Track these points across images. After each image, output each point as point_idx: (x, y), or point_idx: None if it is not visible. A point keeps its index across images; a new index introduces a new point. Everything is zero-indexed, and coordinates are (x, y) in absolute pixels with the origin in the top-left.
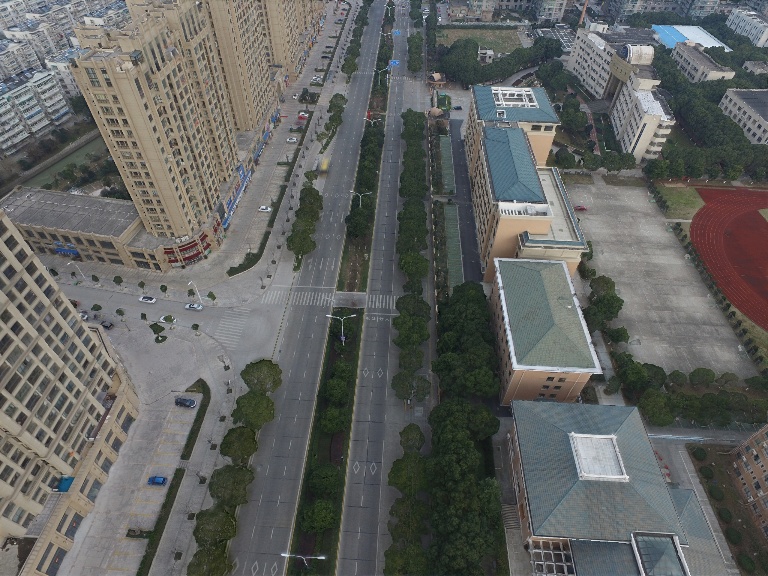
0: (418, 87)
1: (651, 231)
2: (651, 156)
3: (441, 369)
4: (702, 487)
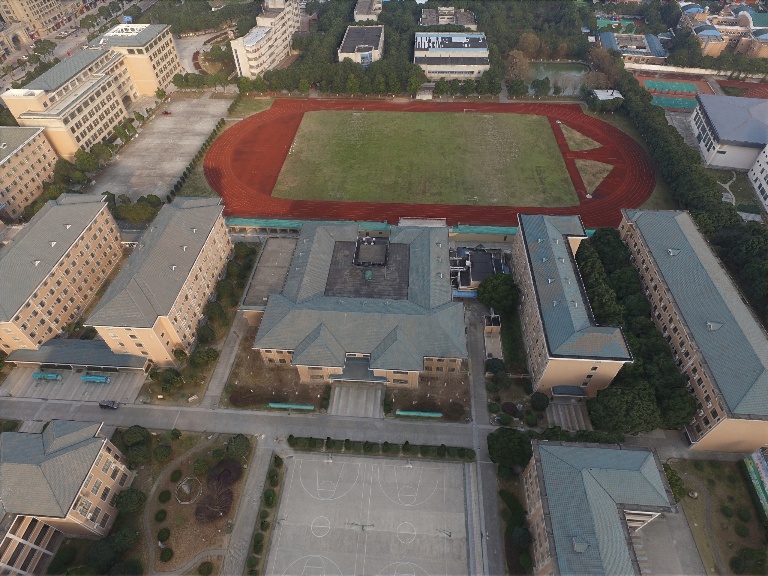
0: None
1: (203, 126)
2: (255, 77)
3: None
4: None
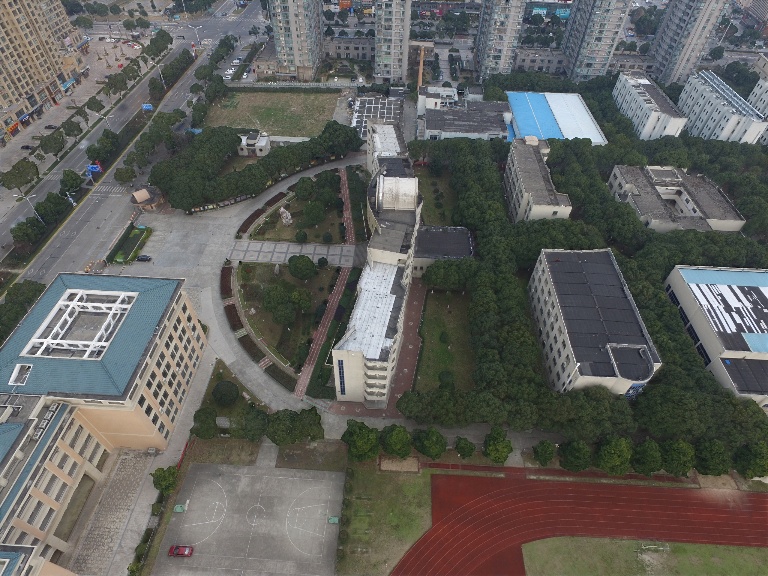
0: (121, 208)
1: None
2: (374, 398)
3: None
4: None
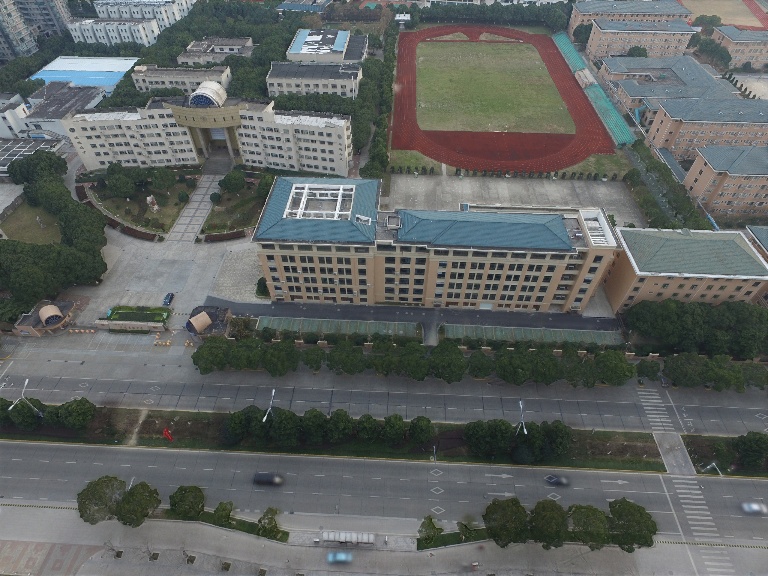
0: (48, 351)
1: (464, 188)
2: None
3: (762, 347)
4: (727, 229)
